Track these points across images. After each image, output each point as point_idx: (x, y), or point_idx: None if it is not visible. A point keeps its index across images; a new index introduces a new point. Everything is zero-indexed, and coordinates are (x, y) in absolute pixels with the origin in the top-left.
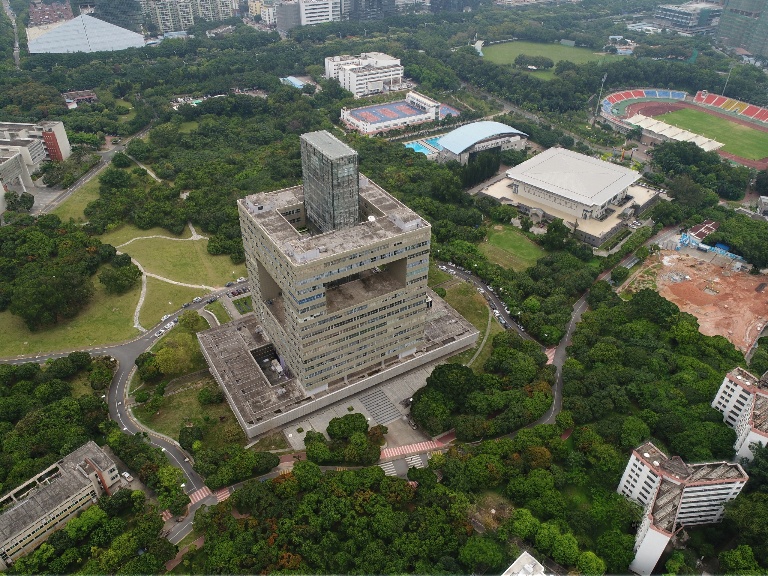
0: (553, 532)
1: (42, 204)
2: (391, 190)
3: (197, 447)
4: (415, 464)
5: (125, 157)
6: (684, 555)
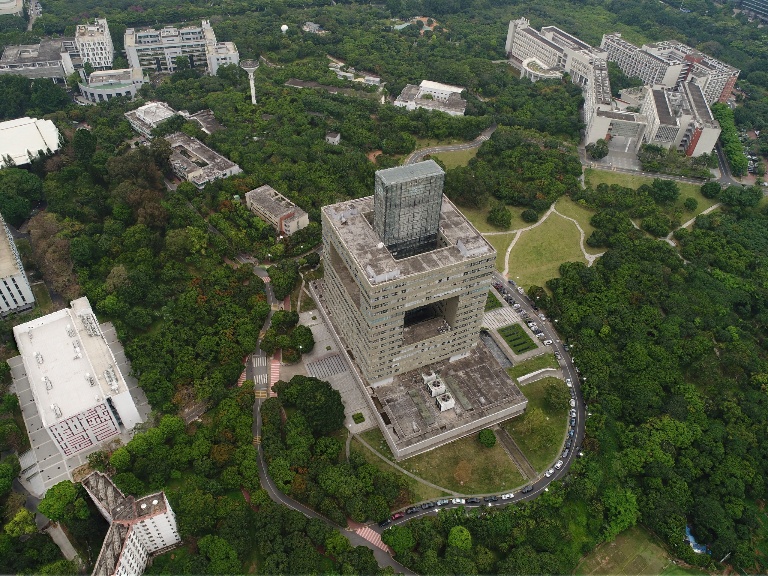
0: (148, 432)
1: (610, 164)
2: (753, 427)
3: (300, 260)
4: (259, 379)
5: (713, 189)
6: (85, 521)
